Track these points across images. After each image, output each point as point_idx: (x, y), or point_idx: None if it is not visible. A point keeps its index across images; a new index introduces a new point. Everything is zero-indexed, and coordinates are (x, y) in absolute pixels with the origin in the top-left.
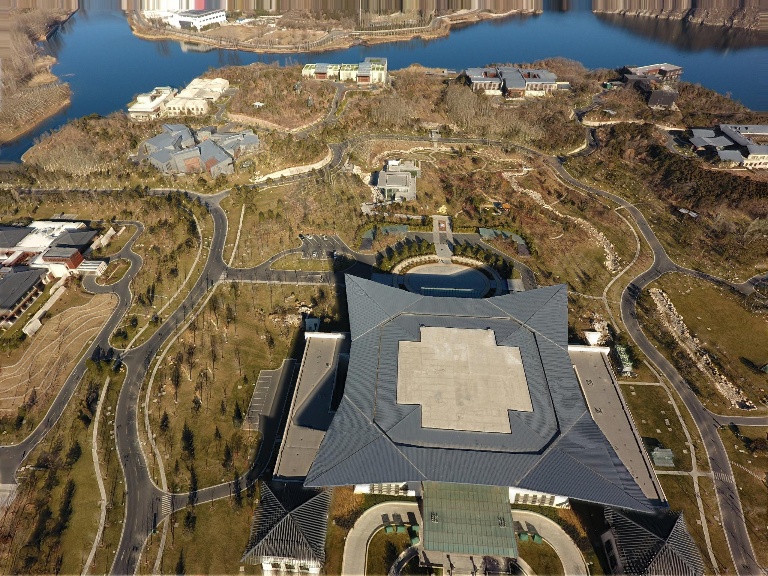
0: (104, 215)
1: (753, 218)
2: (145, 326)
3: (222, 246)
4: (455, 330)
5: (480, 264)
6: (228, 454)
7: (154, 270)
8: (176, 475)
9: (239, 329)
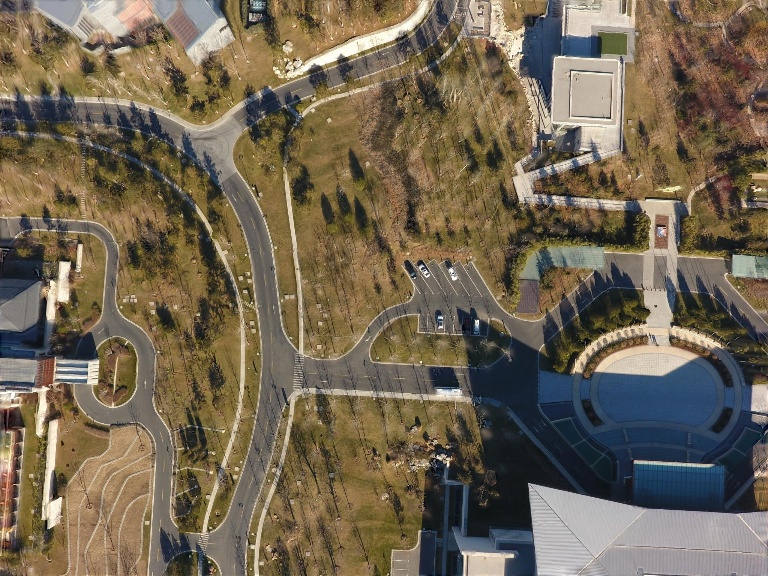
0: (23, 204)
1: None
2: (213, 491)
3: (276, 300)
4: None
5: (716, 347)
6: None
7: (181, 370)
8: None
9: (350, 492)
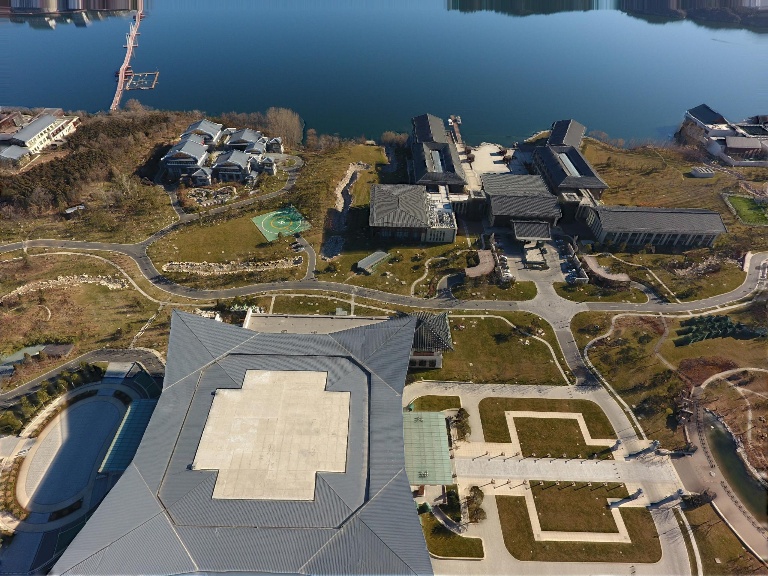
0: None
1: (107, 180)
2: None
3: None
4: (208, 428)
5: (57, 402)
6: None
7: None
8: None
9: None
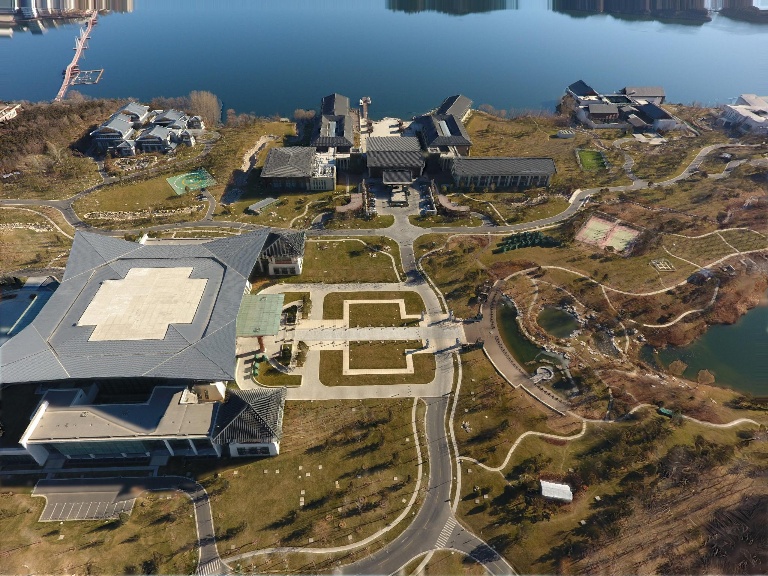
0: None
1: (42, 153)
2: None
3: None
4: (93, 303)
5: None
6: (160, 520)
7: None
8: (175, 571)
9: None
